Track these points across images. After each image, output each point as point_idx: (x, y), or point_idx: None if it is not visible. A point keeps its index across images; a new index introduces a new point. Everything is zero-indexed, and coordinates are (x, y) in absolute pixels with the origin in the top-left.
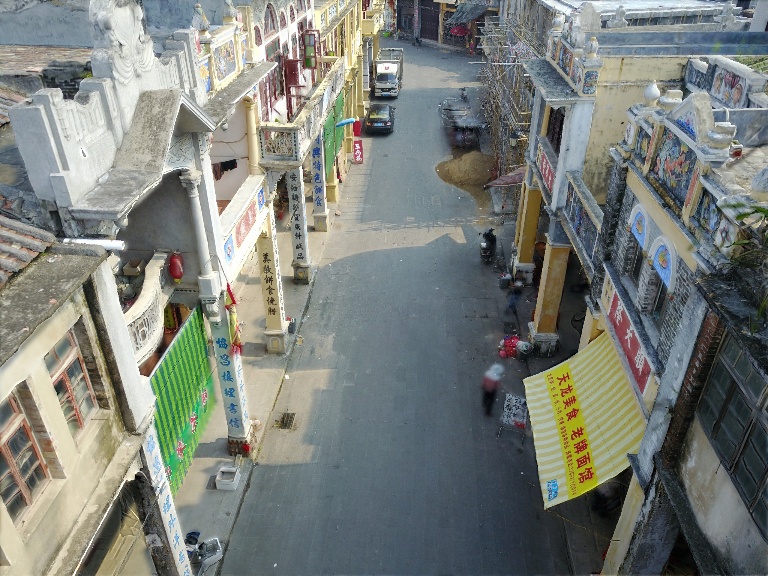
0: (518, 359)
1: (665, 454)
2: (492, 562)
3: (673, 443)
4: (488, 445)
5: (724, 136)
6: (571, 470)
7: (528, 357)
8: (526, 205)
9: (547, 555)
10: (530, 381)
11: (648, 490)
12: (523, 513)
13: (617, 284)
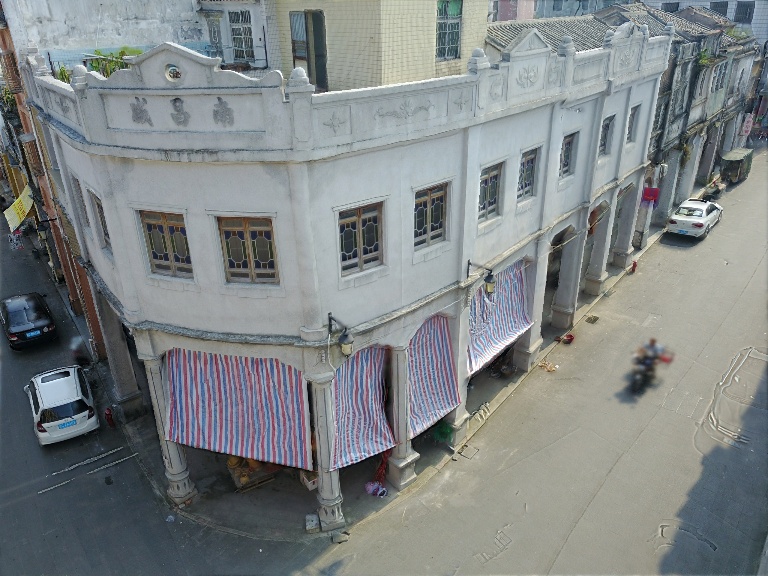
0: (23, 236)
1: (29, 180)
2: (11, 285)
3: (28, 173)
4: (7, 262)
5: (2, 76)
6: (20, 220)
7: (28, 233)
8: (5, 164)
9: (39, 277)
10: (6, 211)
11: (34, 199)
12: (27, 272)
13: (16, 149)
